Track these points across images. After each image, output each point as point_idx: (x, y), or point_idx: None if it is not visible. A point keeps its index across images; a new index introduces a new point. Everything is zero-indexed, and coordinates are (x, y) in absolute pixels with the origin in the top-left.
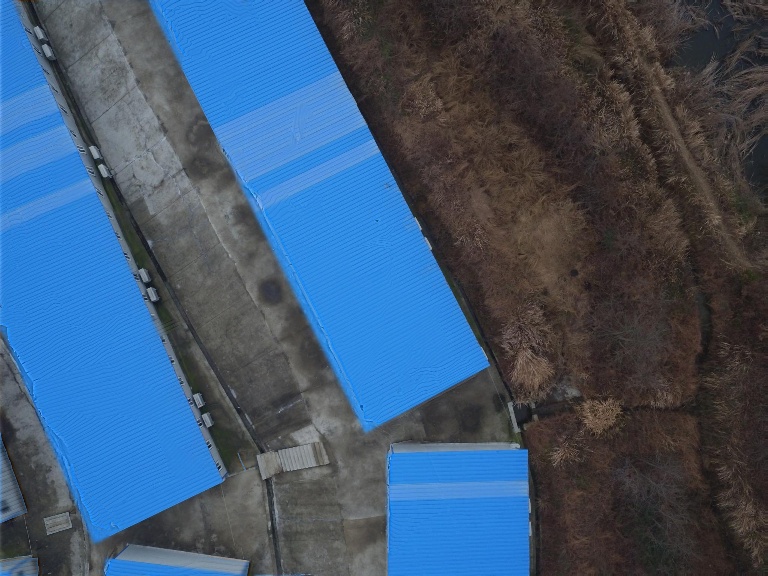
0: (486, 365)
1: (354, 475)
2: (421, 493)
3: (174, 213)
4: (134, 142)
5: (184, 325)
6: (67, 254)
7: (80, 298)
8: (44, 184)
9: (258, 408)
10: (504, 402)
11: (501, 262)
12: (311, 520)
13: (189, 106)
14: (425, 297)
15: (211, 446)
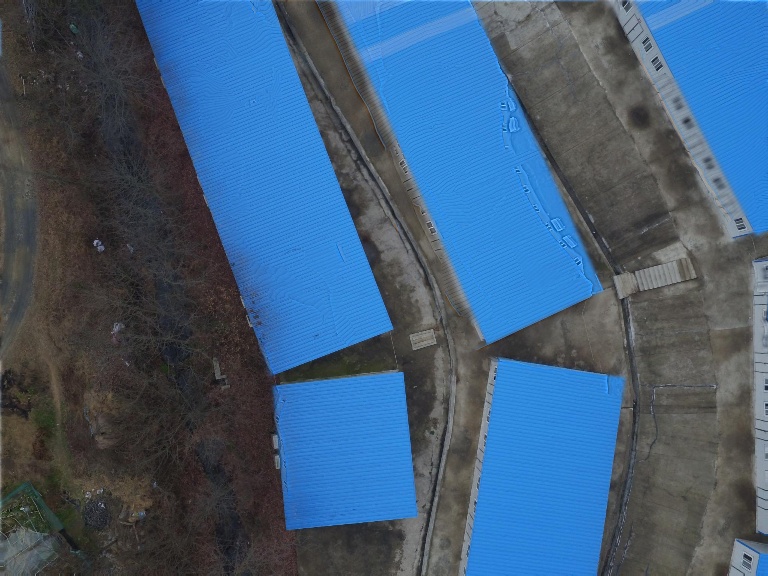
0: None
1: (719, 289)
2: None
3: (539, 46)
4: None
5: (543, 154)
6: (454, 76)
7: (459, 121)
8: (430, 10)
9: (618, 231)
10: None
11: None
12: (674, 333)
13: None
14: None
15: (580, 263)
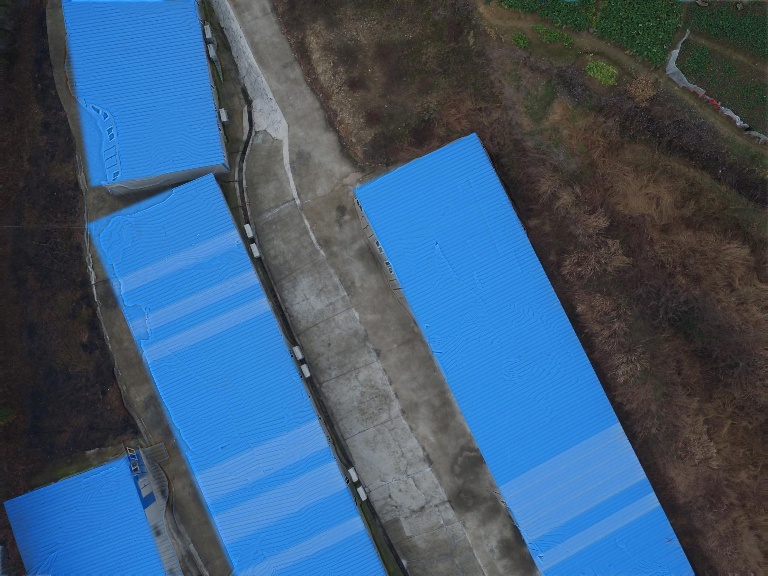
0: None
1: None
2: None
3: (434, 540)
4: (393, 465)
5: None
6: None
7: None
8: (315, 521)
9: None
10: None
11: None
12: None
13: (454, 438)
14: None
15: None
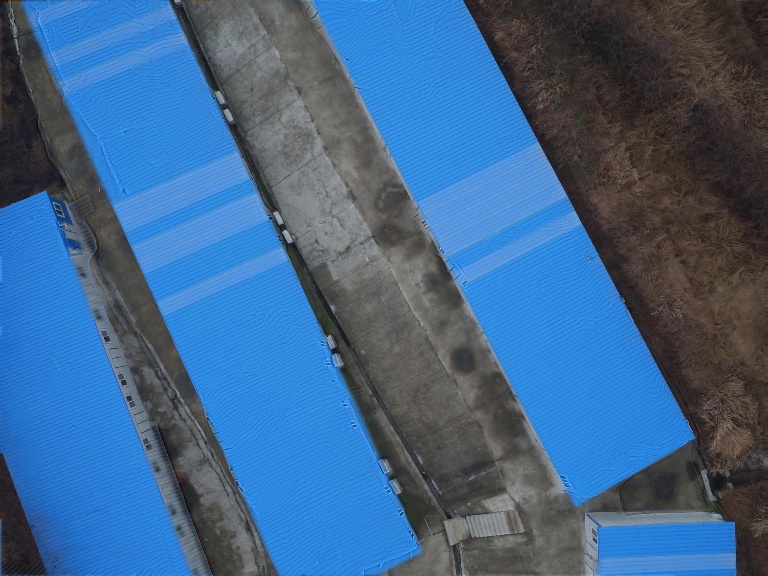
0: (691, 438)
1: (549, 543)
2: (631, 566)
3: (360, 280)
4: (318, 208)
5: (368, 391)
6: (262, 324)
7: (271, 367)
8: (237, 253)
9: (446, 474)
10: (697, 470)
11: (699, 332)
12: None
13: (377, 173)
14: (630, 370)
15: (403, 514)
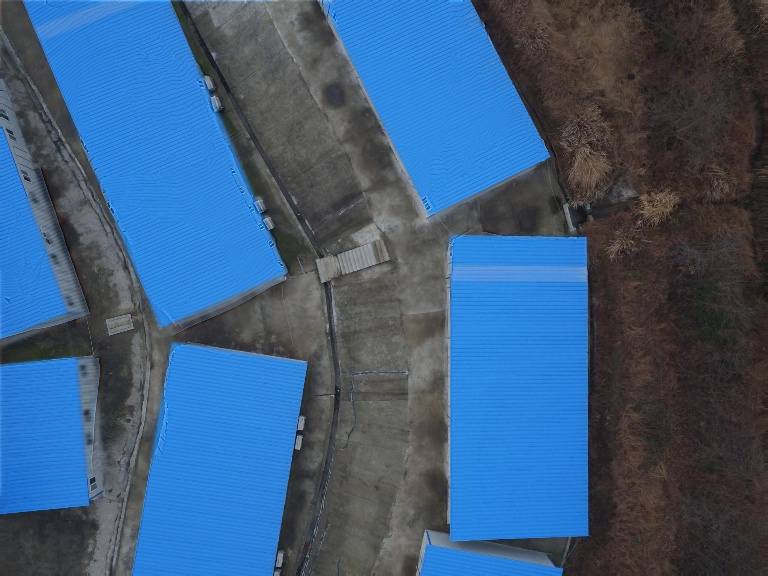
0: (546, 156)
1: (414, 272)
2: (483, 275)
3: (239, 23)
4: None
5: (246, 134)
6: (137, 52)
7: (148, 99)
8: None
9: (318, 213)
10: (560, 204)
11: (560, 64)
12: (370, 318)
13: None
14: (488, 90)
15: (273, 245)
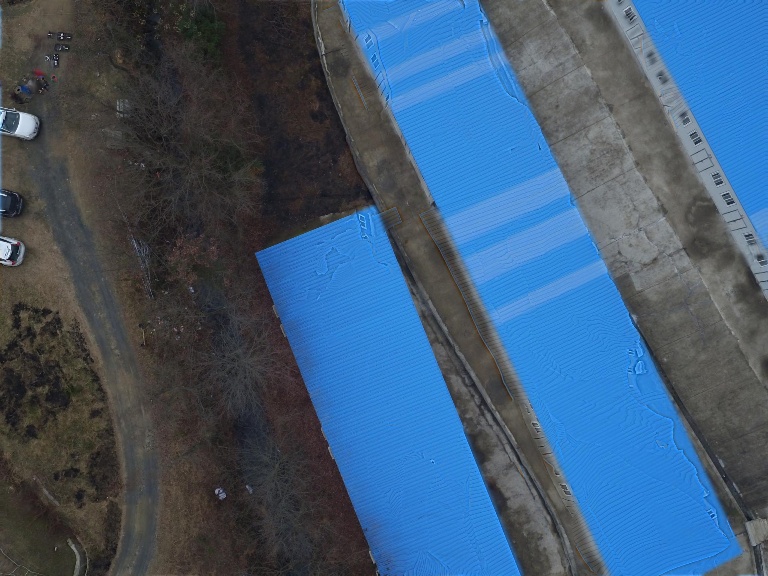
0: None
1: None
2: None
3: (667, 290)
4: (623, 221)
5: (670, 397)
6: (586, 333)
7: (589, 374)
8: (559, 265)
9: (750, 478)
10: None
11: None
12: None
13: (687, 188)
14: None
15: (715, 516)
